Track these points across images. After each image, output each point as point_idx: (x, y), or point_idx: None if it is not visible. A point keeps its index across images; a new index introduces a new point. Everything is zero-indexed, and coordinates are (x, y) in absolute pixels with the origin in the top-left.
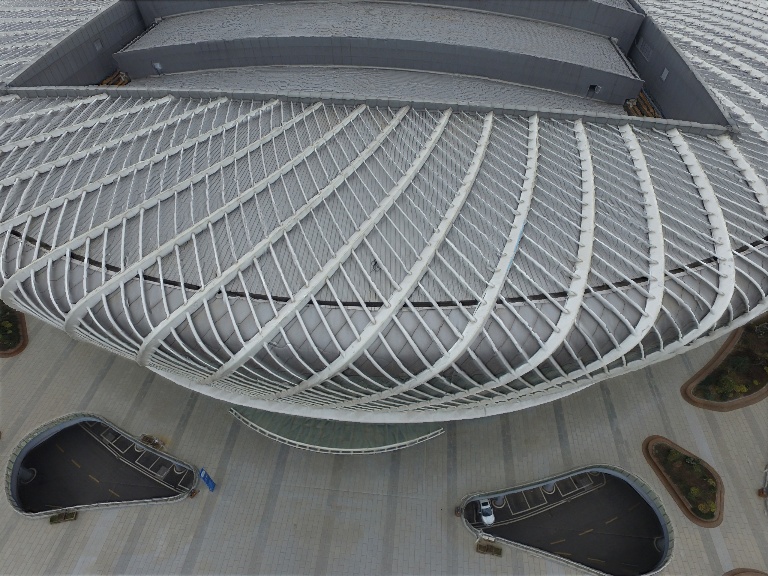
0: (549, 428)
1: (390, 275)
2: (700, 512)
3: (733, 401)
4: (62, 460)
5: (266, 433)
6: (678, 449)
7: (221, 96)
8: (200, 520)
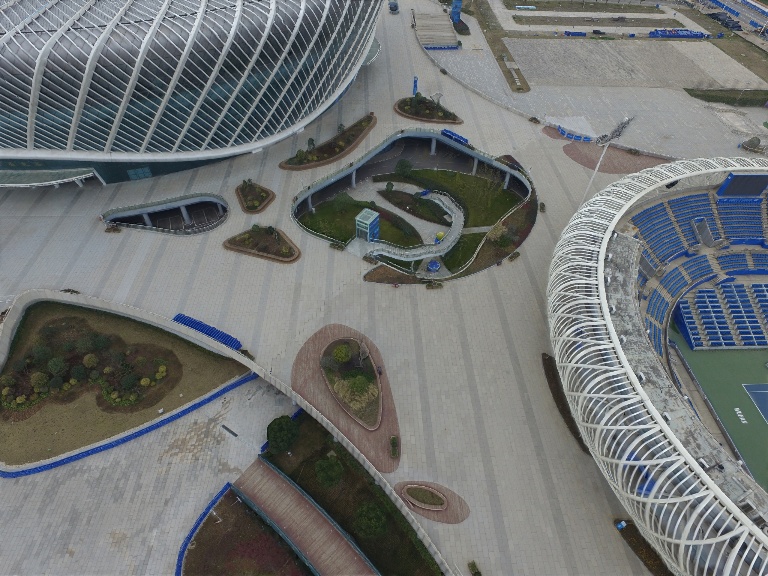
0: (182, 184)
1: None
2: (248, 206)
3: (307, 165)
4: None
5: None
6: (256, 185)
7: None
8: None
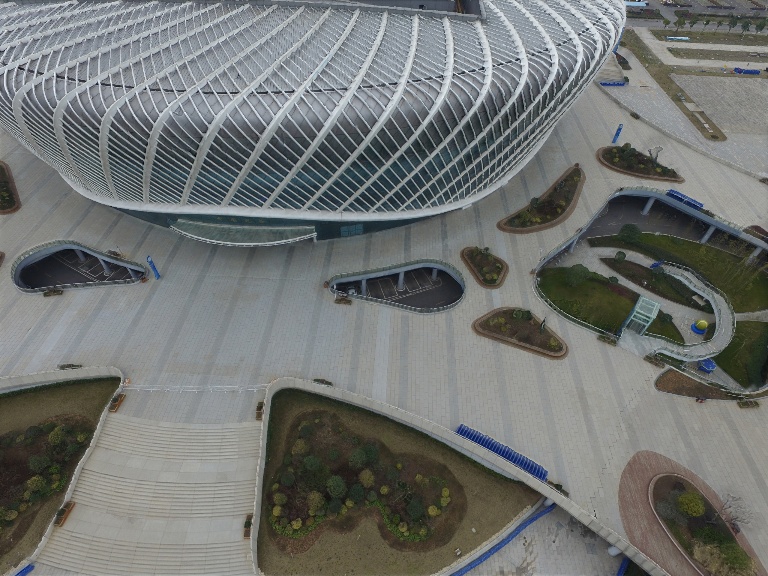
0: (399, 244)
1: (245, 79)
2: (486, 280)
3: (530, 228)
4: (50, 281)
5: (194, 237)
6: None
7: None
8: (148, 293)
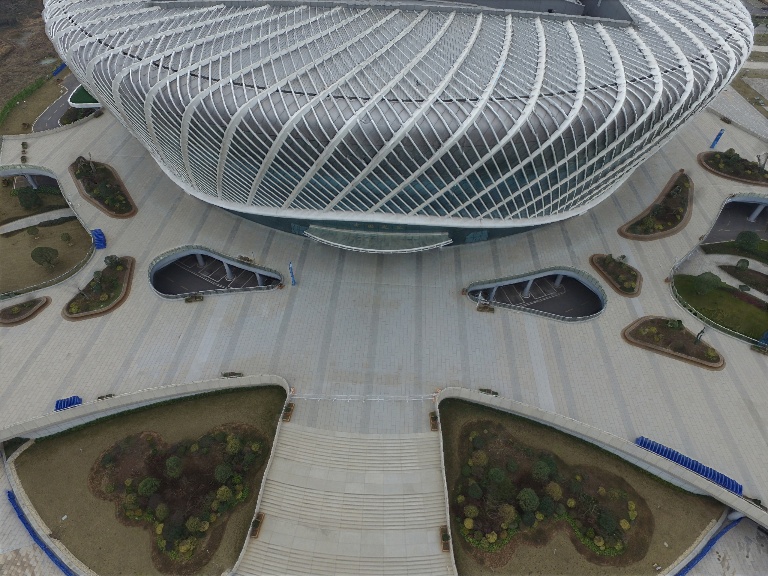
0: (525, 251)
1: (427, 87)
2: (625, 288)
3: (653, 235)
4: (174, 286)
5: (331, 244)
6: None
7: (303, 4)
8: (288, 300)
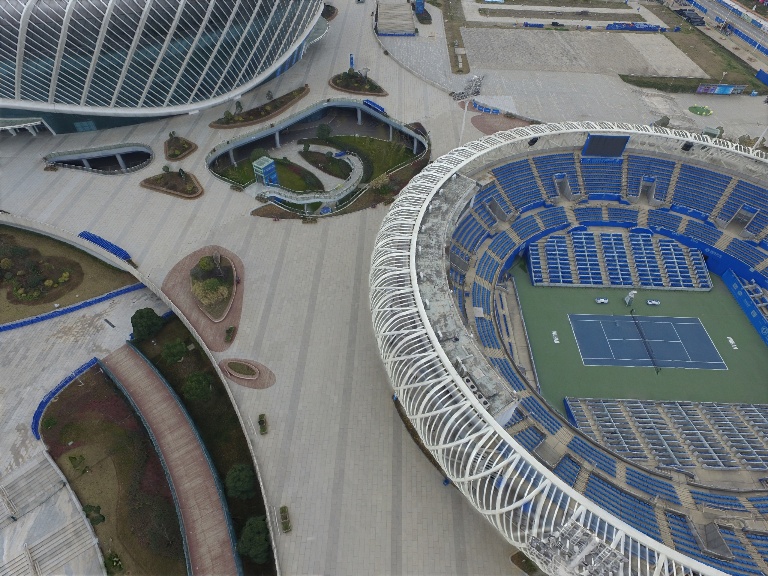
0: (121, 136)
1: None
2: (170, 154)
3: (233, 124)
4: None
5: None
6: (183, 139)
7: None
8: None
